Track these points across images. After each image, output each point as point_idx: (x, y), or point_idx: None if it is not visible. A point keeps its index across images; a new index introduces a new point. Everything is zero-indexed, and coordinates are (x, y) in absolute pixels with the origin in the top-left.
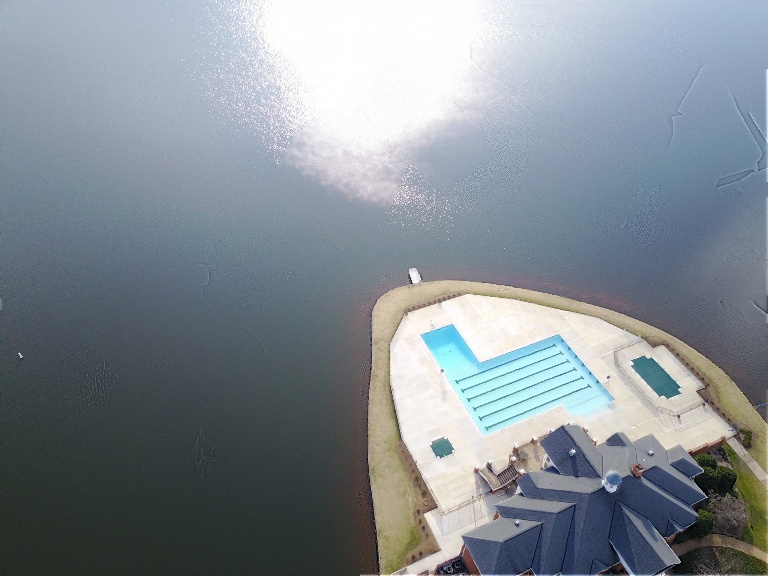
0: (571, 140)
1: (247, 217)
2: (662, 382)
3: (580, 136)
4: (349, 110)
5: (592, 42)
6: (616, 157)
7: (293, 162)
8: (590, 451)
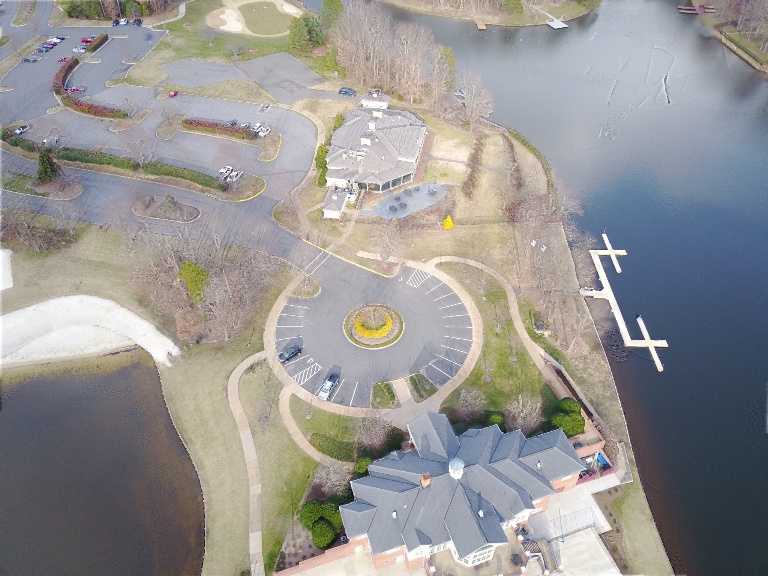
0: None
1: None
2: None
3: None
4: None
5: None
6: None
7: None
8: (460, 518)
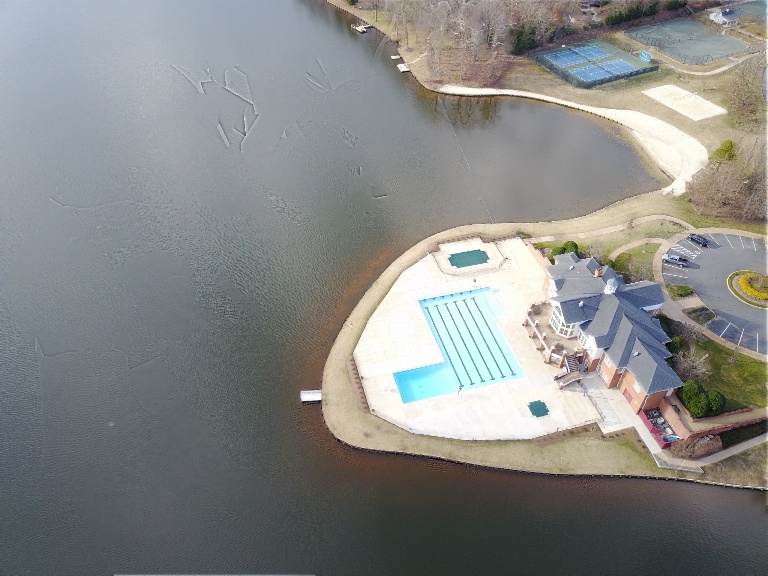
0: (206, 200)
1: (178, 567)
2: (475, 257)
3: (204, 192)
4: (49, 366)
5: (128, 113)
6: (230, 186)
7: (94, 476)
8: None
